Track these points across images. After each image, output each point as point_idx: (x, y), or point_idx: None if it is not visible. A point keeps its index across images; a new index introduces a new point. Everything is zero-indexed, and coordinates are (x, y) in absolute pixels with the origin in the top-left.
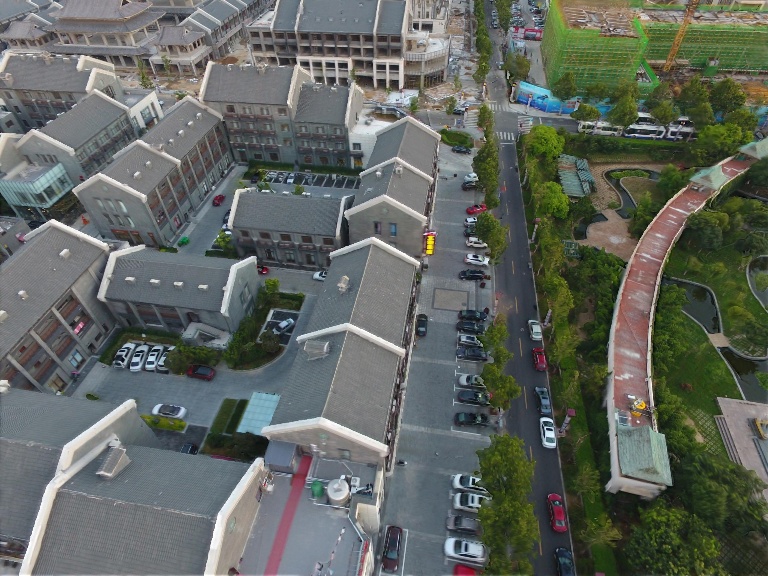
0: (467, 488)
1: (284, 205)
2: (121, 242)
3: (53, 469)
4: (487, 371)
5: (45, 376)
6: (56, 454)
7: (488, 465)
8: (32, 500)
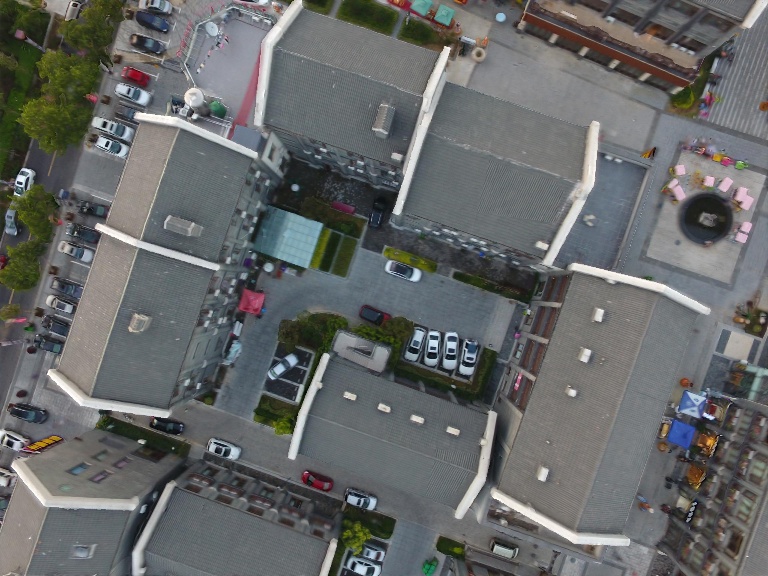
0: (116, 141)
1: (240, 567)
2: (488, 522)
3: (440, 123)
4: (36, 223)
5: (538, 316)
6: (438, 132)
7: (63, 113)
8: (457, 108)
